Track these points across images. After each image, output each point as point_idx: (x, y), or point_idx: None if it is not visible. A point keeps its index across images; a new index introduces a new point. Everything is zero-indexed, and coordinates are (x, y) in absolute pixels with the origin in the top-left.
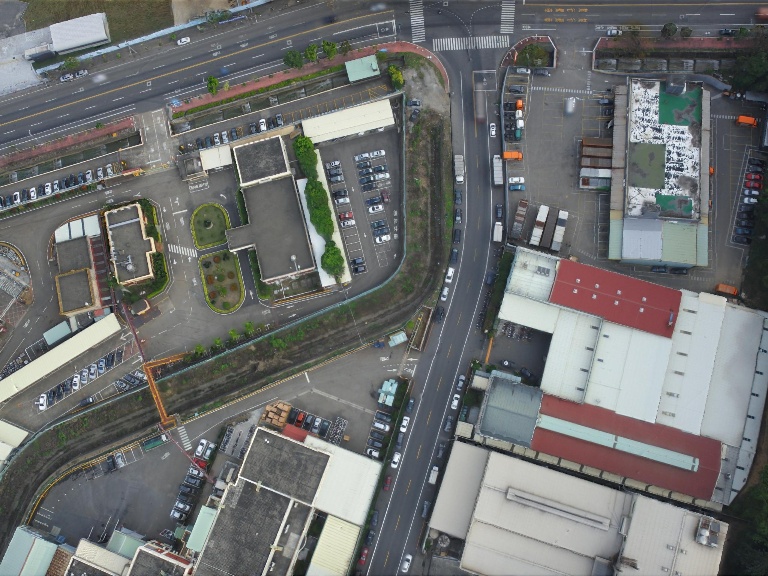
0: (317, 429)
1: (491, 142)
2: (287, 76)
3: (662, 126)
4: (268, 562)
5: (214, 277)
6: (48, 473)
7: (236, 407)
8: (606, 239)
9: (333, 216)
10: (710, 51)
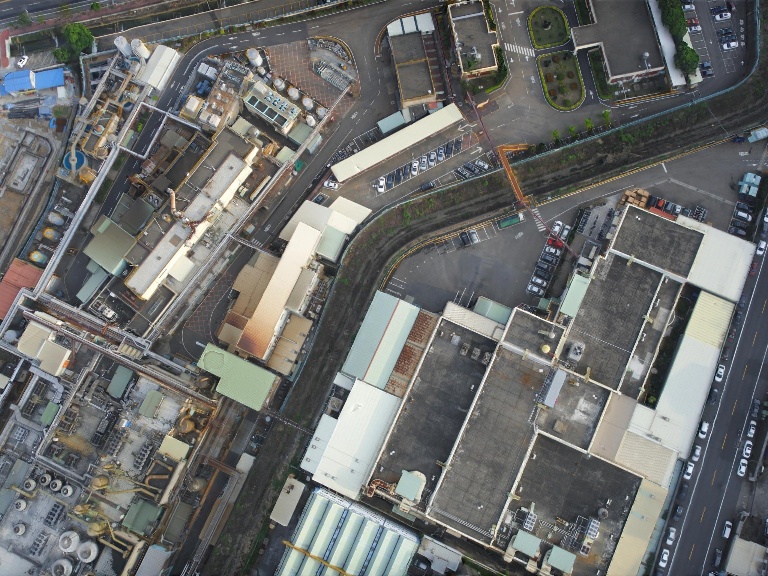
0: None
1: None
2: None
3: None
4: (641, 331)
5: (553, 76)
6: (393, 249)
7: (591, 192)
8: None
9: None
10: None
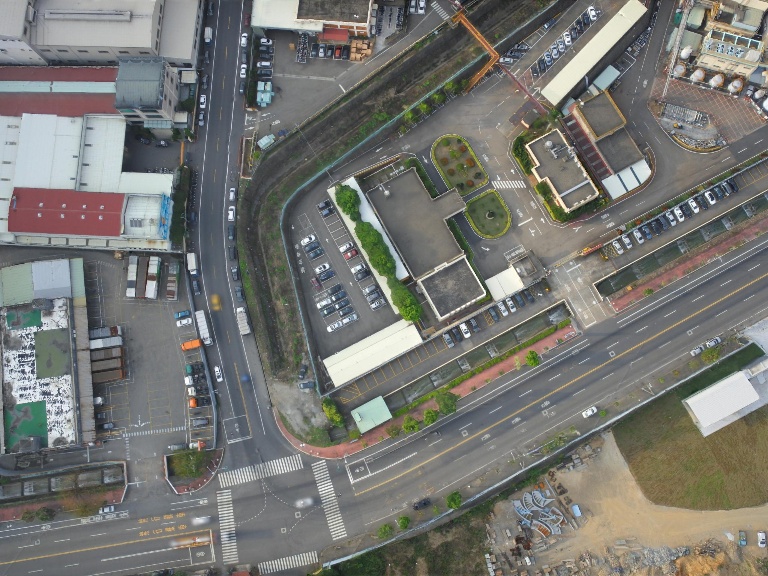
0: (321, 47)
1: (219, 361)
2: (455, 392)
3: (42, 399)
4: None
5: (467, 166)
6: None
7: (401, 48)
8: (91, 283)
9: (361, 248)
10: (6, 505)
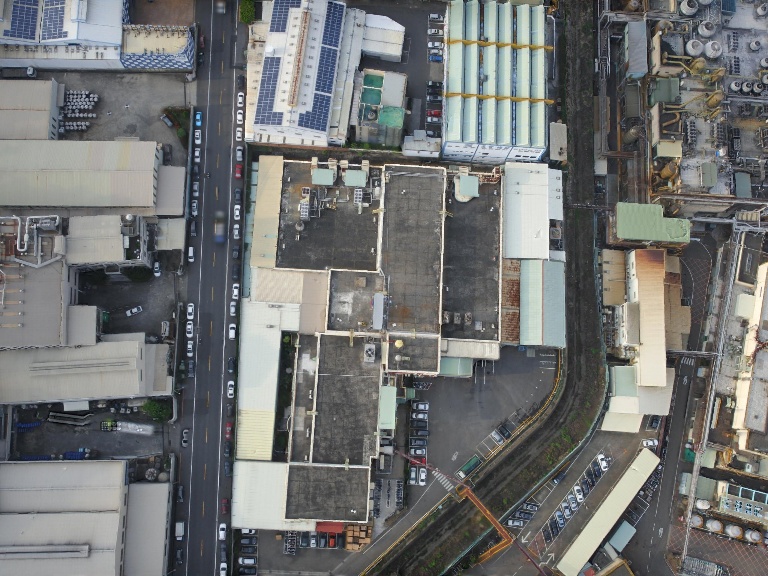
0: (312, 536)
1: None
2: None
3: None
4: (315, 398)
5: None
6: (564, 399)
7: (403, 529)
8: None
9: None
10: None
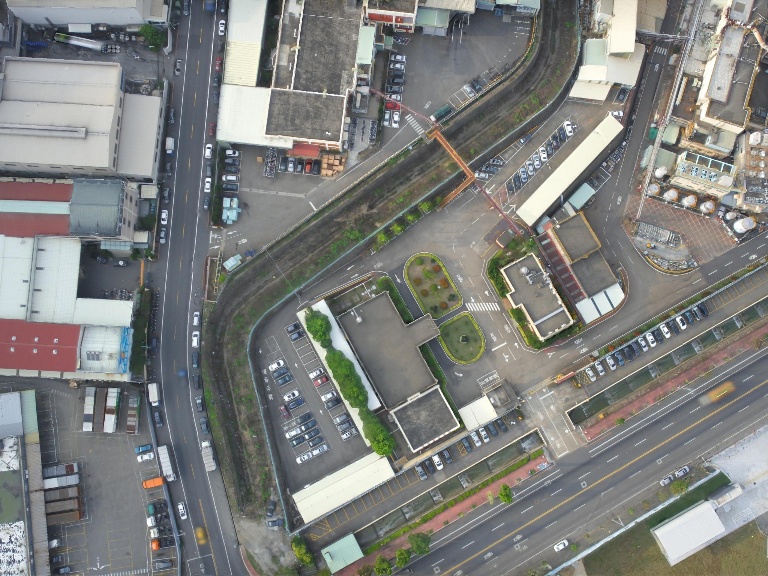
0: (290, 161)
1: (182, 497)
2: (428, 527)
3: None
4: (299, 35)
5: (441, 287)
6: (536, 67)
7: (374, 163)
8: (44, 414)
9: (332, 376)
10: None
